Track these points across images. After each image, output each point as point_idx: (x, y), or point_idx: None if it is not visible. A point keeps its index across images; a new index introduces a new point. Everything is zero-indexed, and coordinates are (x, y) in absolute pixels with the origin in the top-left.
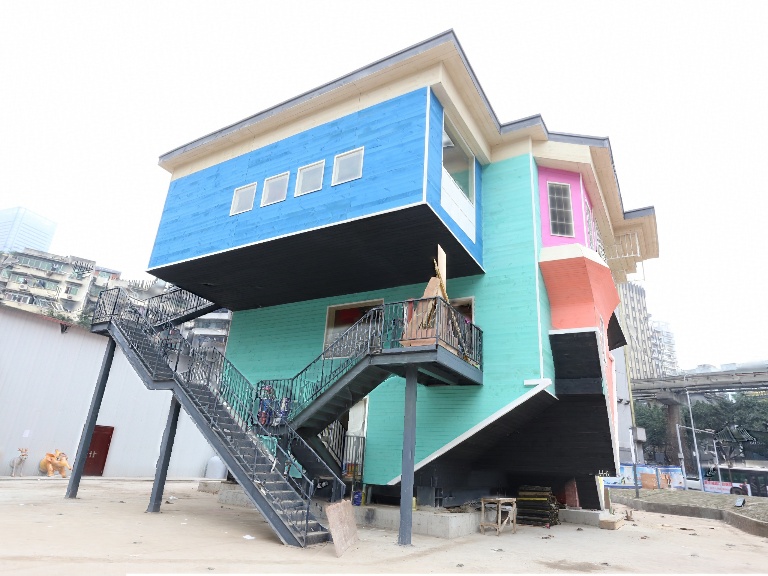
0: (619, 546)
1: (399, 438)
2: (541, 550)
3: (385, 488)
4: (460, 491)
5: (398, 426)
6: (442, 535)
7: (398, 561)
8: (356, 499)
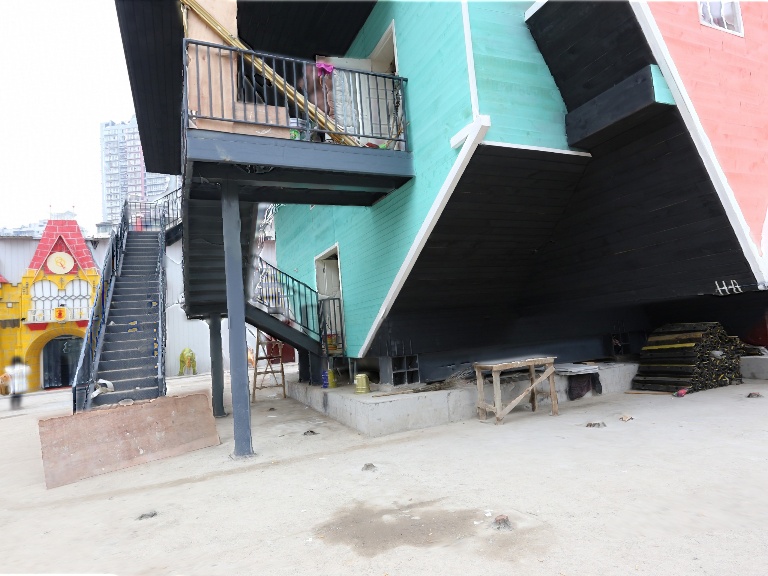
0: (752, 444)
1: (361, 292)
2: (475, 464)
3: (363, 361)
4: (497, 351)
5: (358, 275)
6: (365, 431)
7: (94, 500)
8: (323, 380)
